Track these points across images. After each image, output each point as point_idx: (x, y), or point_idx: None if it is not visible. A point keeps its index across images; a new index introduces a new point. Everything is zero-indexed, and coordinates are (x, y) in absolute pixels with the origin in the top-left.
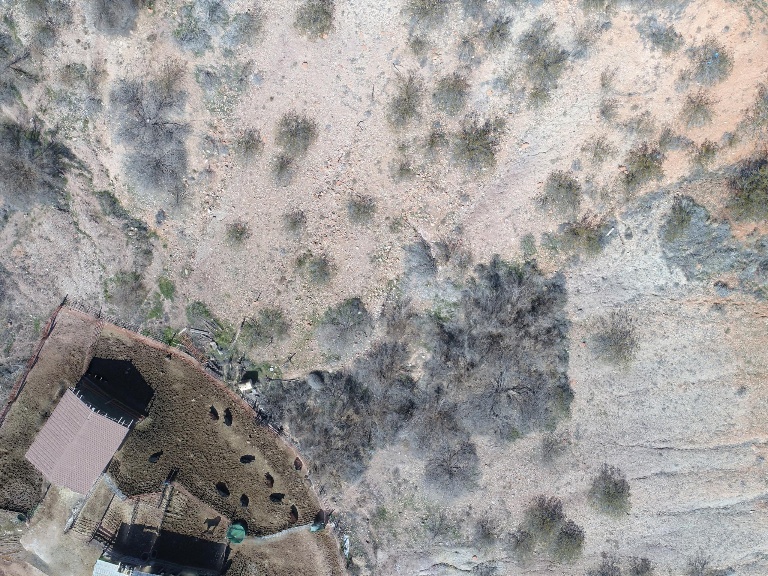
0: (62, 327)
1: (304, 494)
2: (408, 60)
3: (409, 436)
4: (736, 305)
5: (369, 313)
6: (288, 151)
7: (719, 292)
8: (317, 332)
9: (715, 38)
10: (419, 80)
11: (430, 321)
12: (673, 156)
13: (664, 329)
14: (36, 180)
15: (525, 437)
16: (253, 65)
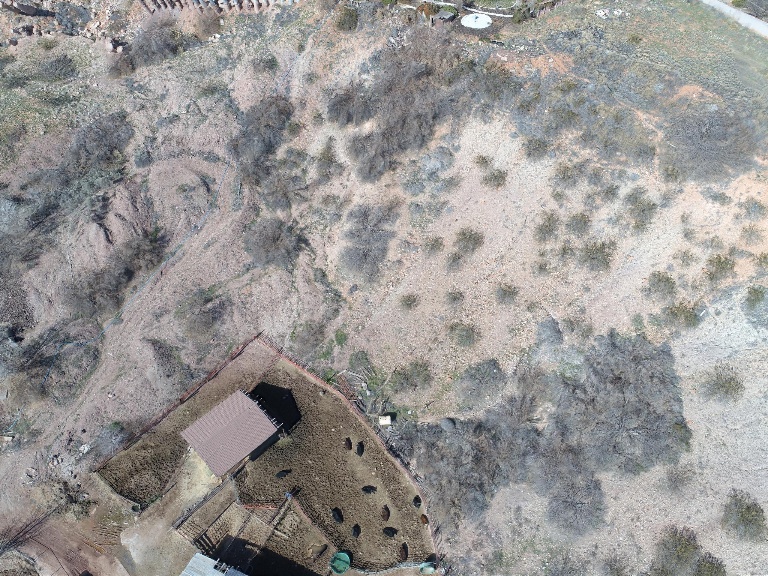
0: (247, 355)
1: (418, 533)
2: (551, 204)
3: (536, 463)
4: None
5: (503, 372)
6: (461, 251)
7: None
8: (456, 385)
9: (753, 198)
10: (557, 216)
11: (556, 379)
12: (741, 262)
13: (762, 371)
14: (283, 246)
15: (649, 471)
16: (448, 203)
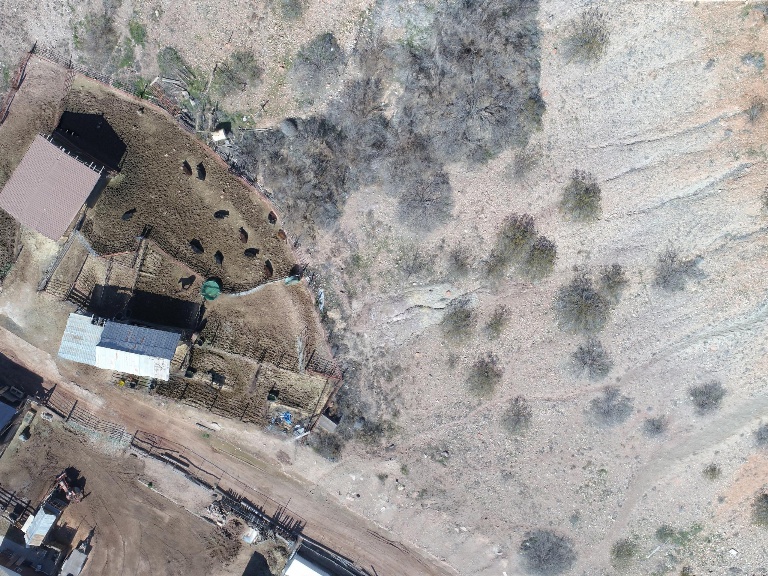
0: (32, 79)
1: (278, 249)
2: None
3: (382, 167)
4: None
5: (341, 49)
6: None
7: None
8: (290, 75)
9: None
10: None
11: (403, 51)
12: None
13: (634, 17)
14: None
15: (497, 157)
16: None
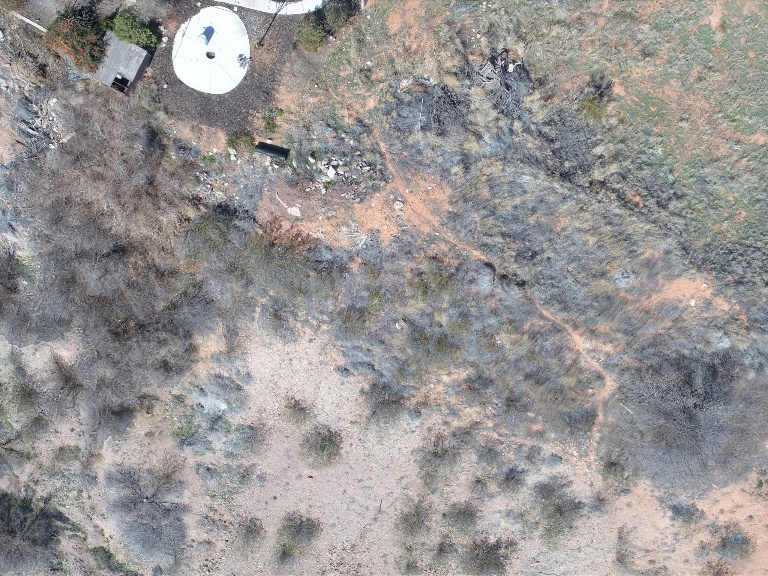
0: None
1: None
2: (418, 487)
3: None
4: None
5: None
6: (291, 540)
7: None
8: None
9: (738, 522)
10: (429, 502)
11: None
12: None
13: None
14: (28, 554)
15: None
16: (256, 467)
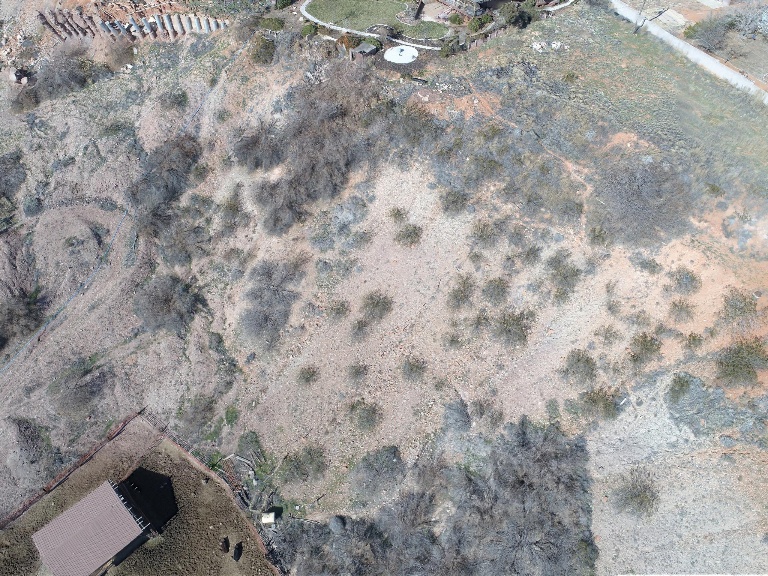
0: (127, 434)
1: None
2: (467, 266)
3: None
4: (743, 454)
5: (403, 461)
6: (367, 317)
7: (724, 442)
8: (351, 475)
9: (685, 267)
10: (473, 280)
11: (459, 474)
12: (668, 343)
13: (681, 481)
14: (175, 309)
15: None
16: (358, 261)
